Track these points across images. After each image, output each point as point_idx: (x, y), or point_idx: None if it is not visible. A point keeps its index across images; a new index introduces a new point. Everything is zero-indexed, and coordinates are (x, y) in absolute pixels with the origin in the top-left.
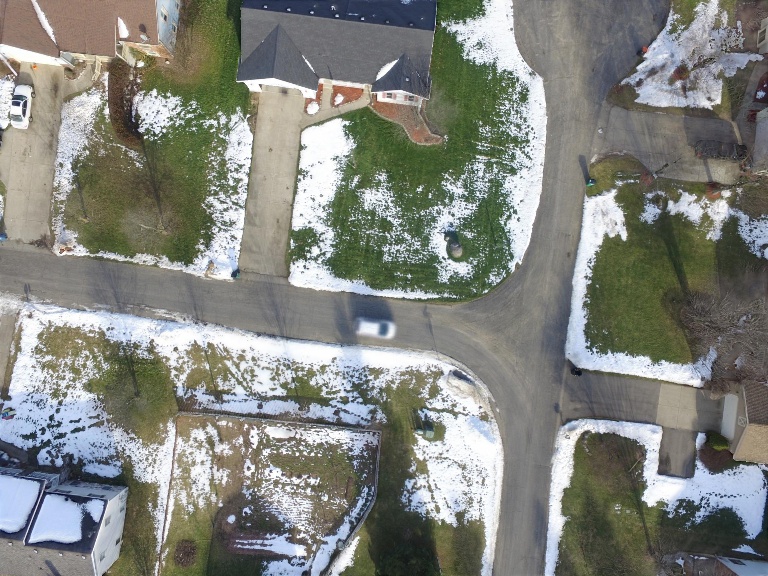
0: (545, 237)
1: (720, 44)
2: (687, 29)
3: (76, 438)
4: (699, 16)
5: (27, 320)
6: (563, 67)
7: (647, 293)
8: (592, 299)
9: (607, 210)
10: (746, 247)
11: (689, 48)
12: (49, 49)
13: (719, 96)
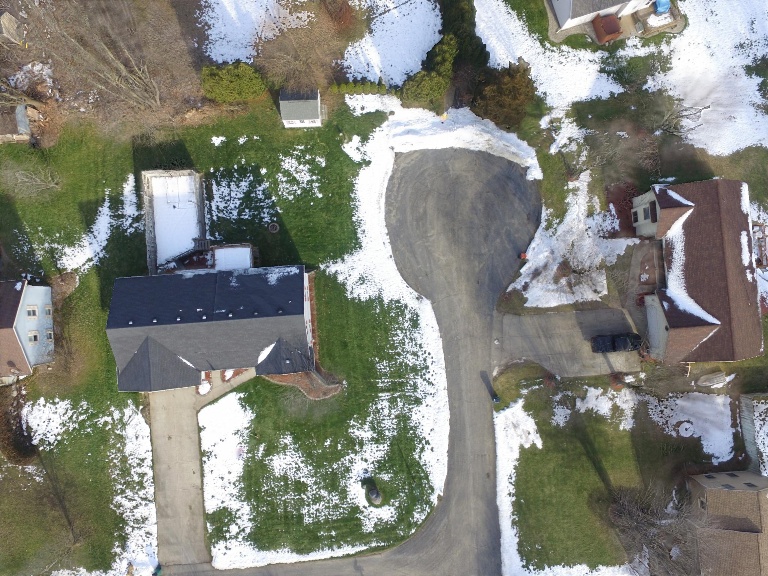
0: (462, 462)
1: (597, 231)
2: (562, 222)
3: None
4: (571, 206)
5: None
6: (448, 285)
7: (572, 498)
8: (519, 515)
9: (518, 421)
10: (660, 429)
11: (567, 241)
12: None
13: (605, 287)
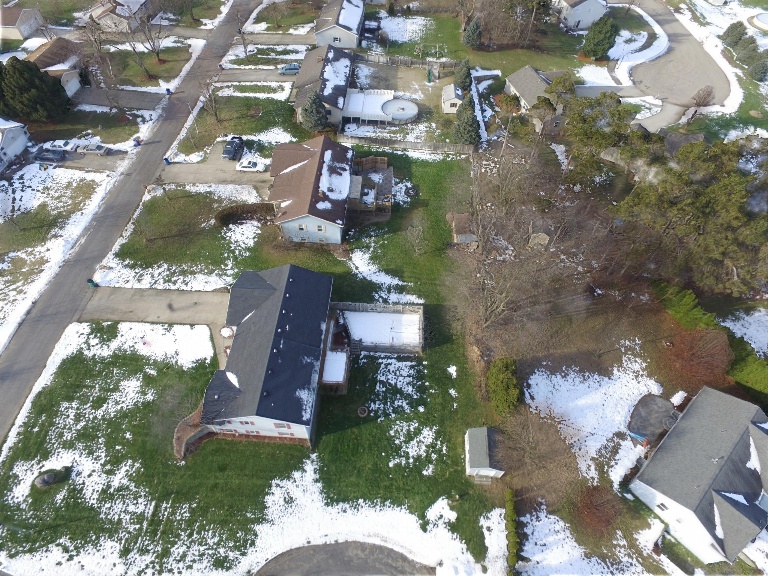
0: None
1: None
2: None
3: (9, 199)
4: None
5: (106, 174)
6: None
7: None
8: None
9: None
10: None
11: None
12: (275, 171)
13: None
